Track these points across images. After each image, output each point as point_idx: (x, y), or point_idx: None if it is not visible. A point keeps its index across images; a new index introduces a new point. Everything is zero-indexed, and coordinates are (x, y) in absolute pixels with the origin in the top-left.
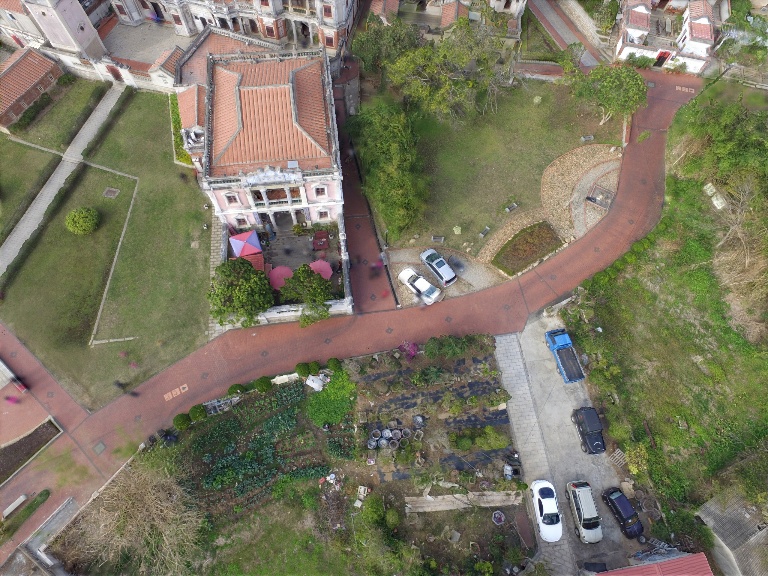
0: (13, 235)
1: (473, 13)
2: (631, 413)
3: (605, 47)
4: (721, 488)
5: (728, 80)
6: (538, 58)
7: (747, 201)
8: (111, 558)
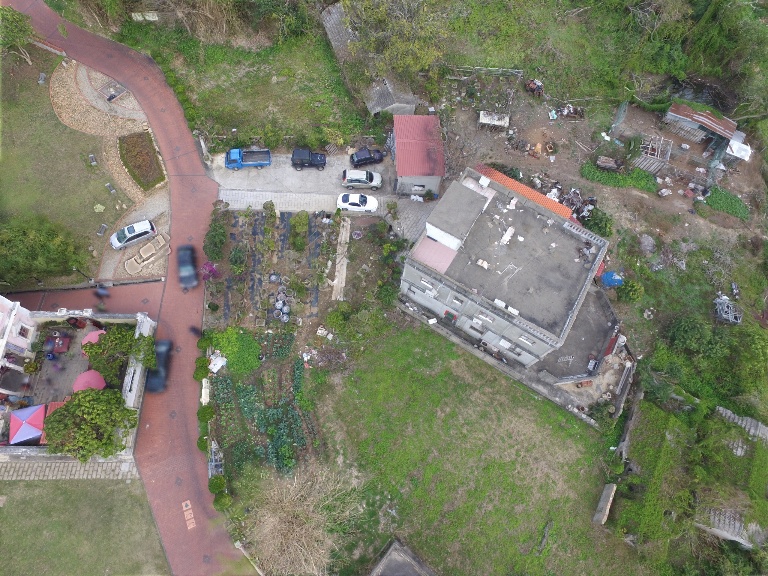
0: None
1: None
2: None
3: None
4: None
5: None
6: None
7: None
8: (337, 569)
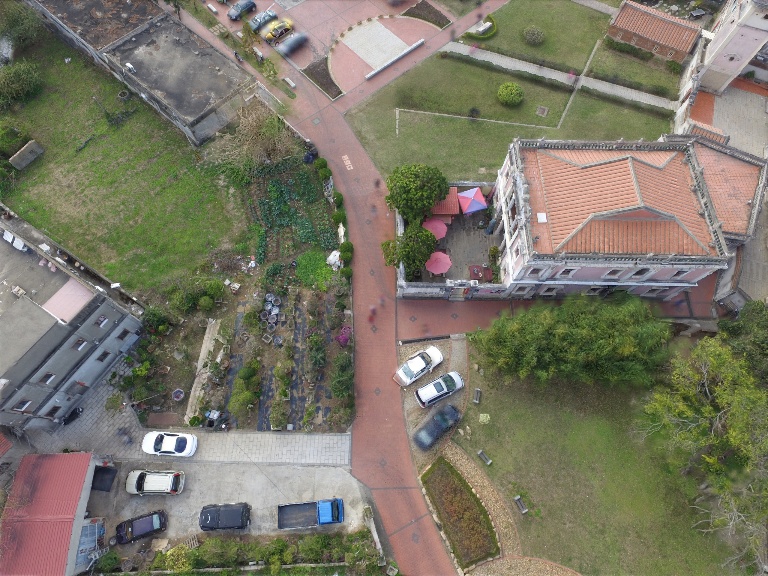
0: (499, 56)
1: None
2: None
3: None
4: None
5: None
6: None
7: None
8: None
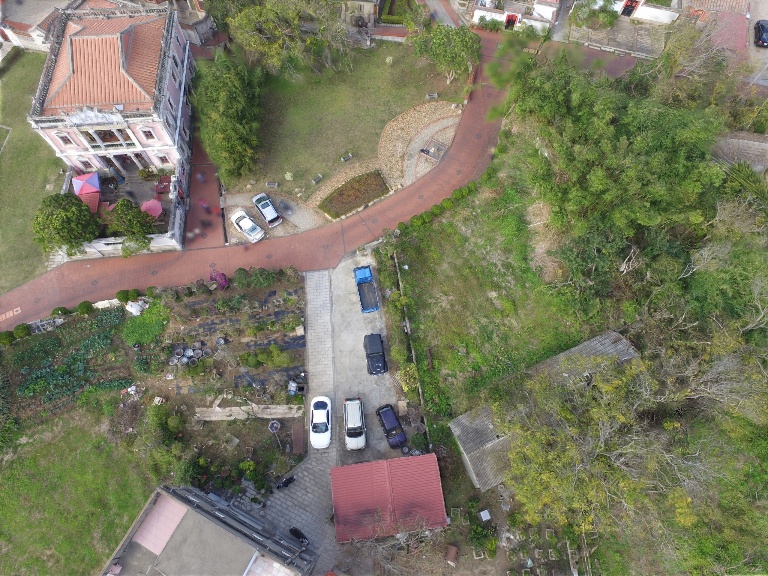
0: None
1: None
2: (417, 340)
3: (464, 12)
4: (477, 404)
5: (575, 43)
6: (397, 22)
7: (543, 147)
8: None
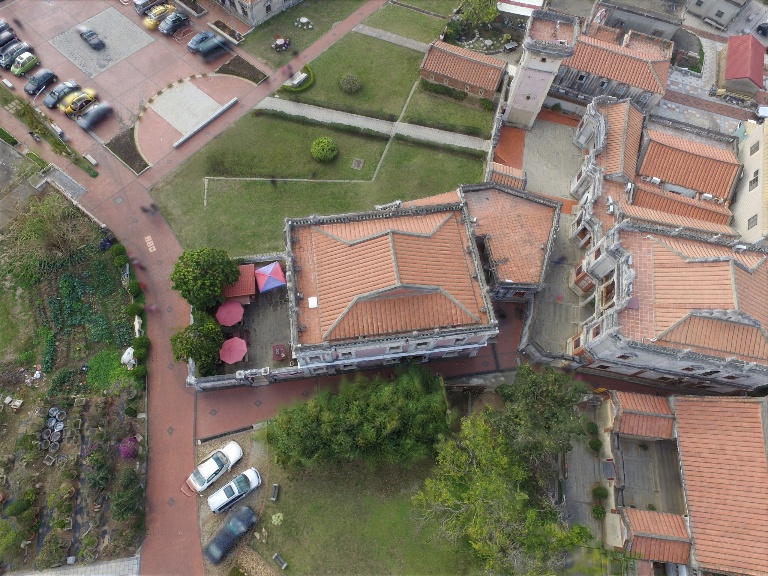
0: (315, 108)
1: (685, 574)
2: None
3: None
4: None
5: None
6: None
7: None
8: None
